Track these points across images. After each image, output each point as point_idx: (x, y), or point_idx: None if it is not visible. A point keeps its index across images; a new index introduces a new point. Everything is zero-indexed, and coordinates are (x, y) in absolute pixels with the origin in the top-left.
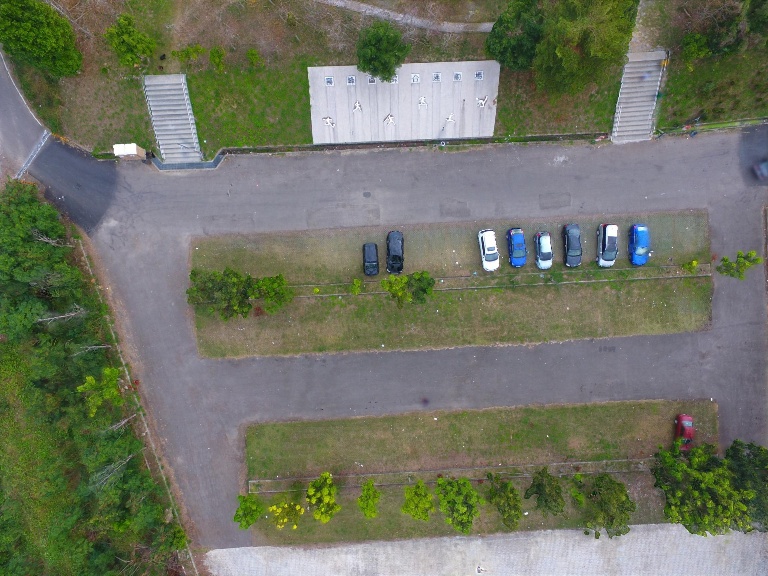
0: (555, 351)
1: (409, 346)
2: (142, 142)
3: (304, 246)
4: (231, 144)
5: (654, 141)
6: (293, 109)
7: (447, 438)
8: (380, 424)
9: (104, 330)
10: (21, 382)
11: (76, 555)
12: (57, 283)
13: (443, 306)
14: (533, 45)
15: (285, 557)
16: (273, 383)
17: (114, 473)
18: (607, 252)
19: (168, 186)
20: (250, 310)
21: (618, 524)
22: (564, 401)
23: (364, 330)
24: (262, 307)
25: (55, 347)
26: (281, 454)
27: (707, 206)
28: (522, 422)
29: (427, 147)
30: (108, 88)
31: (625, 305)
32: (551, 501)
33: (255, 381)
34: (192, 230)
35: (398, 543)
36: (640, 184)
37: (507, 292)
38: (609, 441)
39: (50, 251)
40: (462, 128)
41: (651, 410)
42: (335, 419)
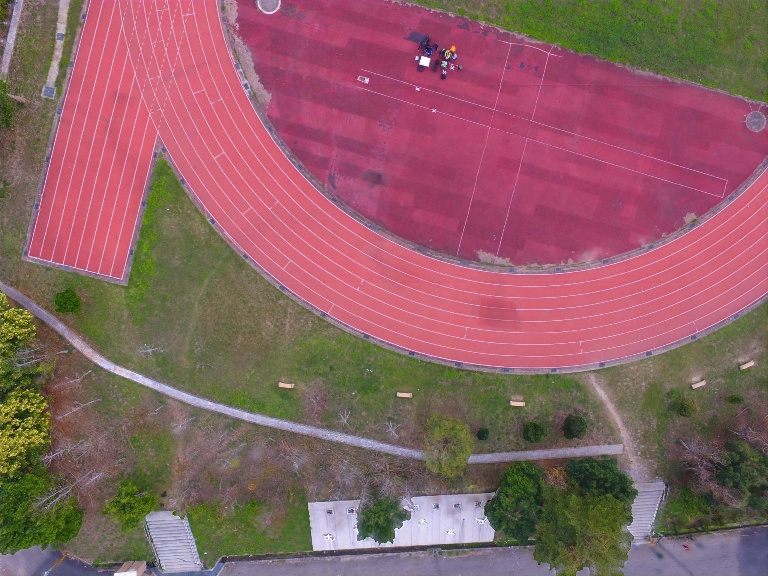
0: None
1: None
2: (142, 555)
3: None
4: (231, 553)
5: (653, 545)
6: (293, 530)
7: None
8: None
9: None
10: None
11: None
12: None
13: None
14: (532, 528)
15: None
16: None
17: None
18: None
19: None
20: None
21: None
22: None
23: None
24: None
25: None
26: None
27: None
28: None
29: (427, 552)
30: (109, 522)
31: None
32: None
33: None
34: None
35: None
36: None
37: None
38: None
39: None
40: (462, 537)
41: None
42: None
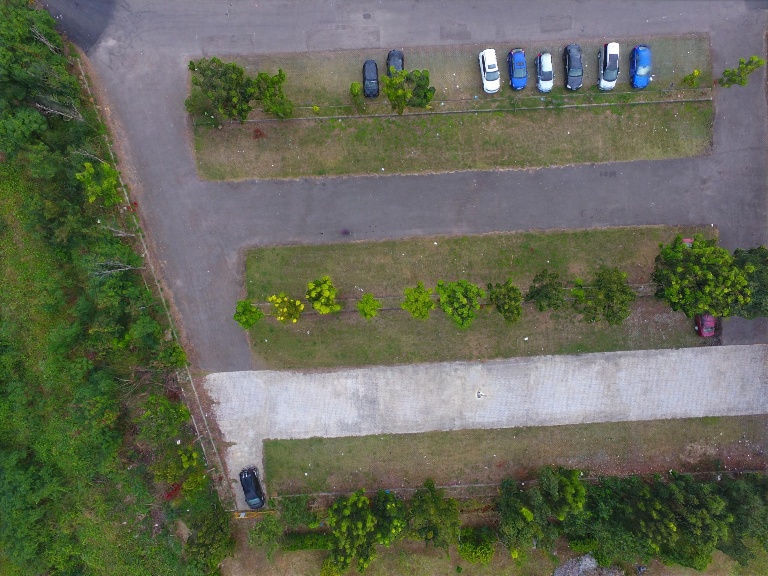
0: (556, 176)
1: (409, 170)
2: None
3: (304, 68)
4: None
5: None
6: None
7: (447, 263)
8: (380, 248)
9: (103, 149)
10: (19, 202)
11: (75, 370)
12: (55, 83)
13: (443, 130)
14: None
15: (285, 381)
16: (273, 206)
17: (113, 279)
18: (608, 71)
19: (167, 5)
20: (249, 132)
21: (618, 308)
22: (564, 226)
23: (364, 153)
24: (261, 129)
25: (53, 153)
26: (281, 278)
27: (709, 30)
28: (522, 247)
29: None
30: None
31: (626, 130)
32: (551, 290)
33: (254, 204)
34: (191, 51)
35: (398, 368)
36: (642, 7)
37: (508, 116)
38: (609, 267)
39: (48, 54)
40: None
41: (652, 236)
42: (335, 243)
